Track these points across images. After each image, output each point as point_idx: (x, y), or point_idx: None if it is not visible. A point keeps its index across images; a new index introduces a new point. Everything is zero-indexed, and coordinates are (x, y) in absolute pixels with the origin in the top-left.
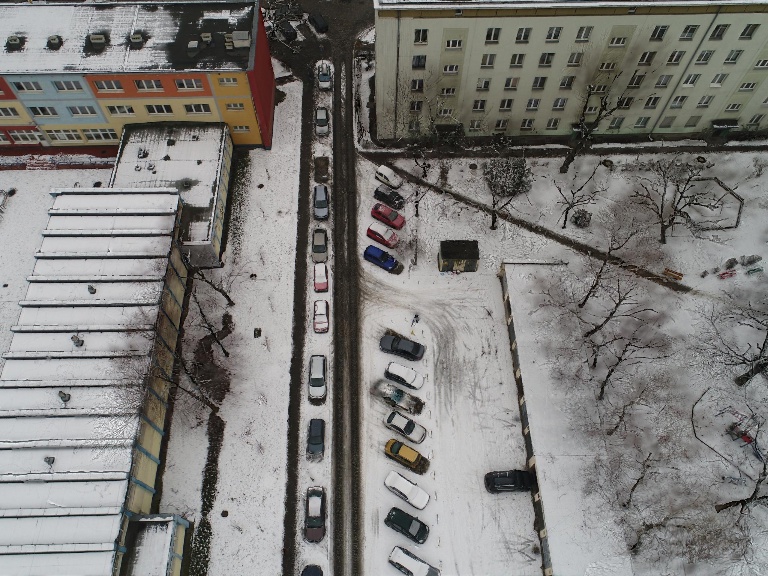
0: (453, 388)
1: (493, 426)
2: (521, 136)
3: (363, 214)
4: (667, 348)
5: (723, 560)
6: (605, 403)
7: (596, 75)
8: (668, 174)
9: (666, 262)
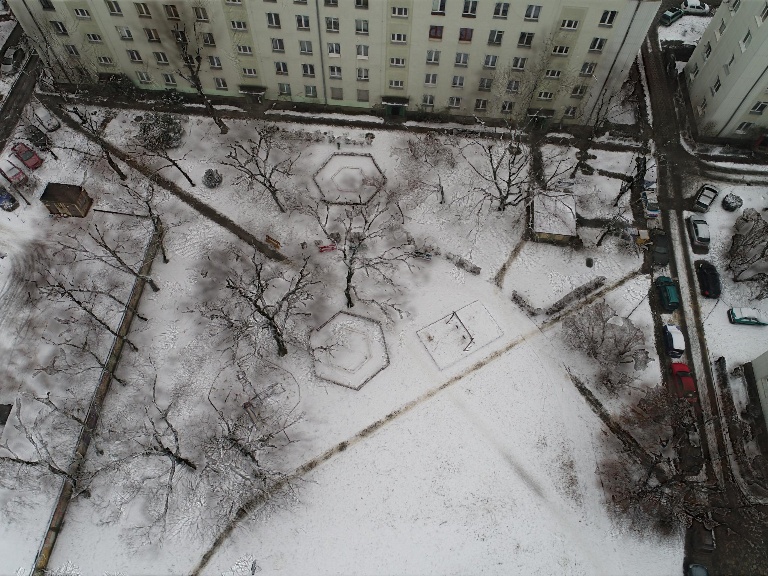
0: (3, 323)
1: (21, 363)
2: (196, 94)
3: (8, 152)
4: (229, 311)
5: (169, 516)
6: (137, 355)
7: (232, 34)
8: (271, 139)
9: (276, 230)
